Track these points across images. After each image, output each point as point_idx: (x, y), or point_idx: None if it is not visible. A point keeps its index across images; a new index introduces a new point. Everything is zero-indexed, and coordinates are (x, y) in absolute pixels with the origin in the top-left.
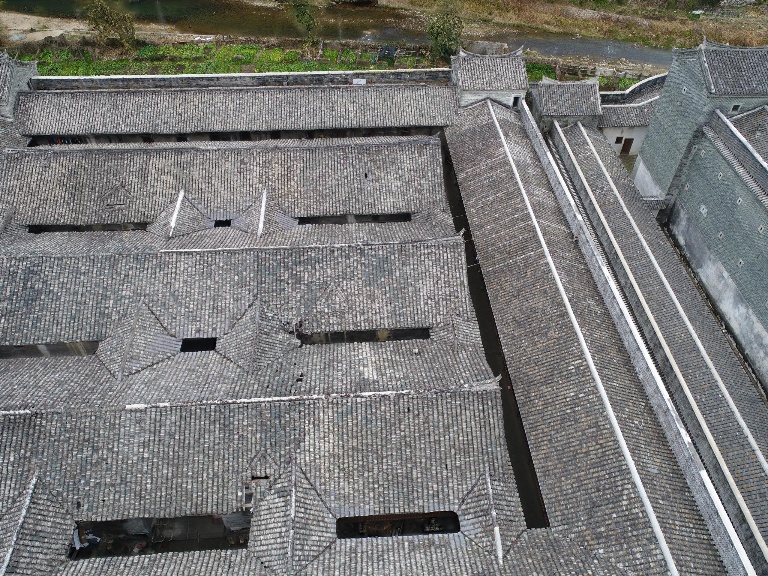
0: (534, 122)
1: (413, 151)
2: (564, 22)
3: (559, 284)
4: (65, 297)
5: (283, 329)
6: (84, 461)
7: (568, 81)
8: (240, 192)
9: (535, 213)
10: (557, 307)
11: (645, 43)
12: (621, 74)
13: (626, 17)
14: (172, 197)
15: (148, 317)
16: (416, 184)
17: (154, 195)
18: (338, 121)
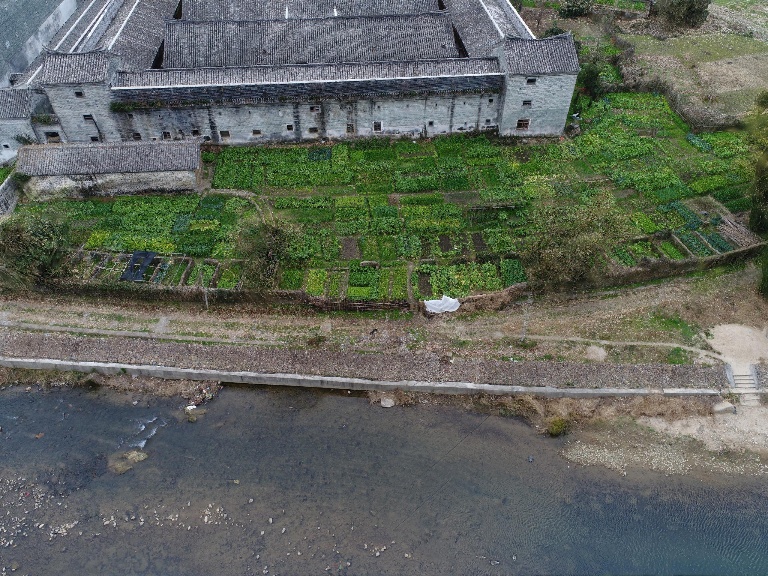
0: None
1: None
2: None
3: None
4: None
5: None
6: None
7: None
8: None
9: None
10: None
11: None
12: None
13: None
14: None
15: None
16: None
17: None
18: None
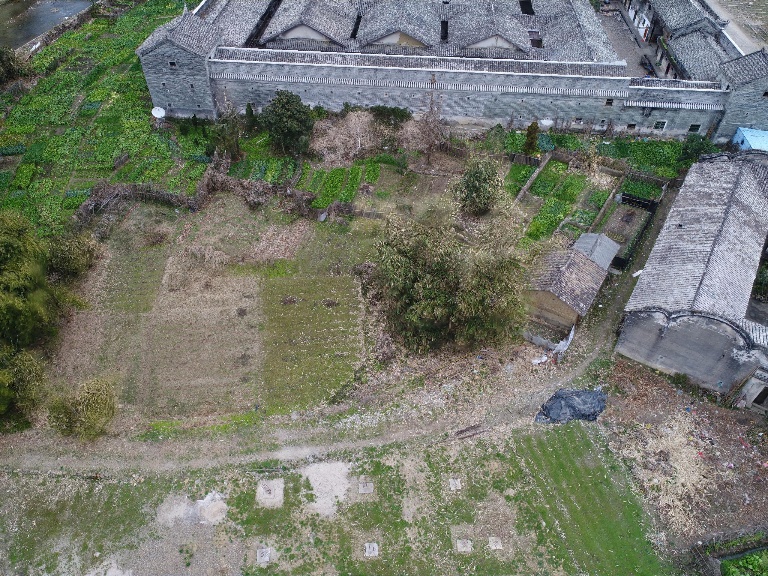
0: None
1: None
2: None
3: None
4: None
5: None
6: (506, 7)
7: None
8: None
9: None
10: None
11: None
12: None
13: None
14: (347, 1)
15: None
16: None
17: (344, 4)
18: None
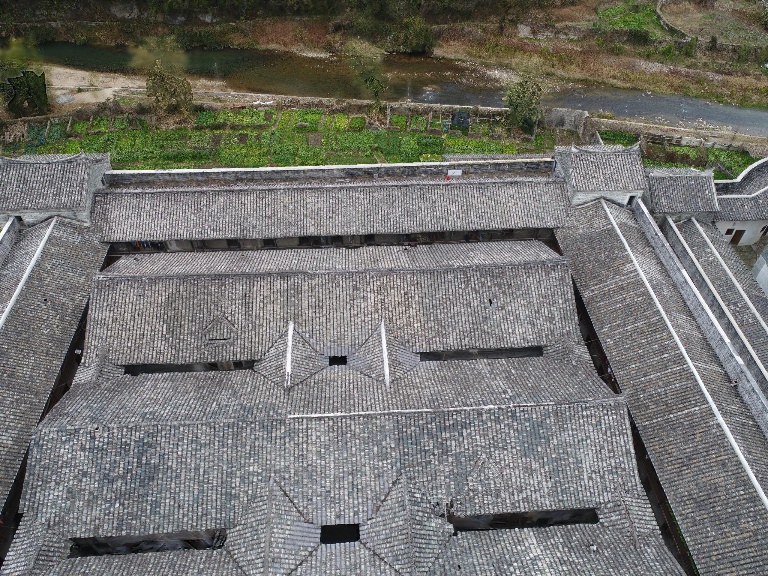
0: (658, 229)
1: (540, 273)
2: (632, 77)
3: (741, 456)
4: (185, 474)
5: (433, 512)
6: None
7: (674, 168)
8: (354, 323)
9: (688, 353)
10: (744, 488)
11: (719, 100)
12: (709, 144)
13: (696, 71)
14: (281, 330)
15: (281, 500)
16: (546, 312)
17: (261, 328)
18: (440, 223)
